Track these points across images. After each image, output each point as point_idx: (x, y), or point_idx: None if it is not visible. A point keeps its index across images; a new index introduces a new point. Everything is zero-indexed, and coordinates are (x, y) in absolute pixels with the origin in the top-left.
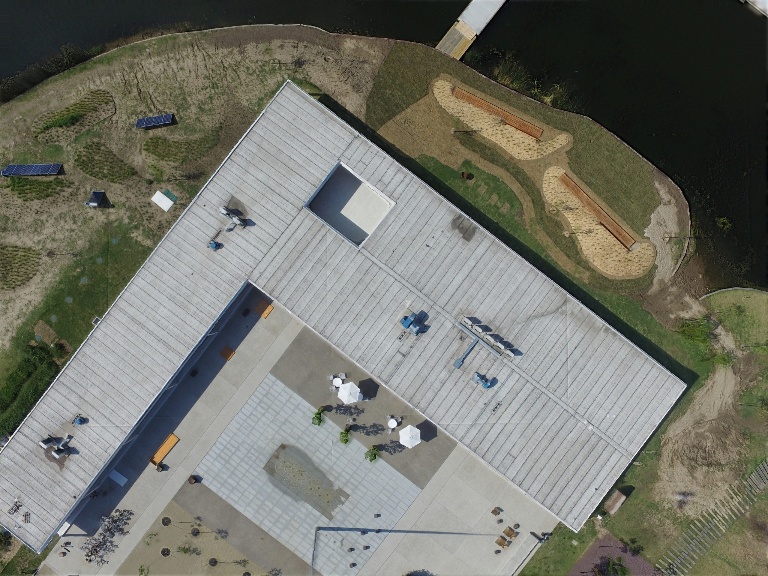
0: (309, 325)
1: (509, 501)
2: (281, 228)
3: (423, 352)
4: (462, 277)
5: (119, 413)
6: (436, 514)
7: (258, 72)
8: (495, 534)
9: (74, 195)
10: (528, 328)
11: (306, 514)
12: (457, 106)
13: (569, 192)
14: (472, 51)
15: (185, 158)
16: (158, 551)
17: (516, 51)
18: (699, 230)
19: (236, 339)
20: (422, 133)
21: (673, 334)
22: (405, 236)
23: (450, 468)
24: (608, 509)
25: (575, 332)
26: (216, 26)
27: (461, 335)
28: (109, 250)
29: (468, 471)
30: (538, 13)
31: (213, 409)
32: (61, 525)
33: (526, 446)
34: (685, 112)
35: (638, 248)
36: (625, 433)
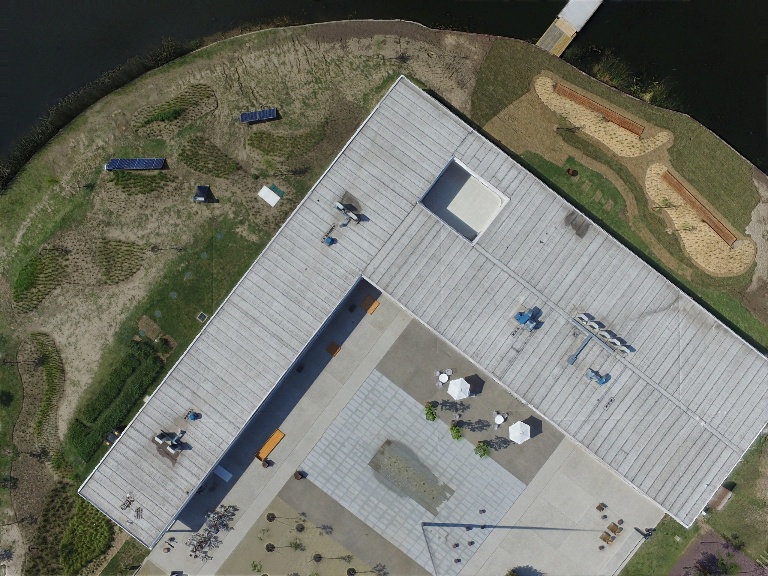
0: (423, 321)
1: (613, 497)
2: (395, 224)
3: (537, 348)
4: (575, 273)
5: (232, 408)
6: (541, 510)
7: (362, 67)
8: (599, 530)
9: (178, 190)
10: (641, 324)
11: (411, 510)
12: (559, 103)
13: (671, 189)
14: (572, 48)
15: (291, 153)
16: (262, 547)
17: (615, 48)
18: None
19: (342, 335)
20: (526, 129)
21: None
22: (519, 232)
23: (555, 464)
24: (714, 505)
25: (687, 329)
26: (315, 21)
27: (574, 331)
28: (214, 245)
29: (573, 467)
30: (636, 10)
31: (318, 405)
32: (173, 520)
33: (638, 442)
34: None
35: (740, 245)
36: (736, 429)
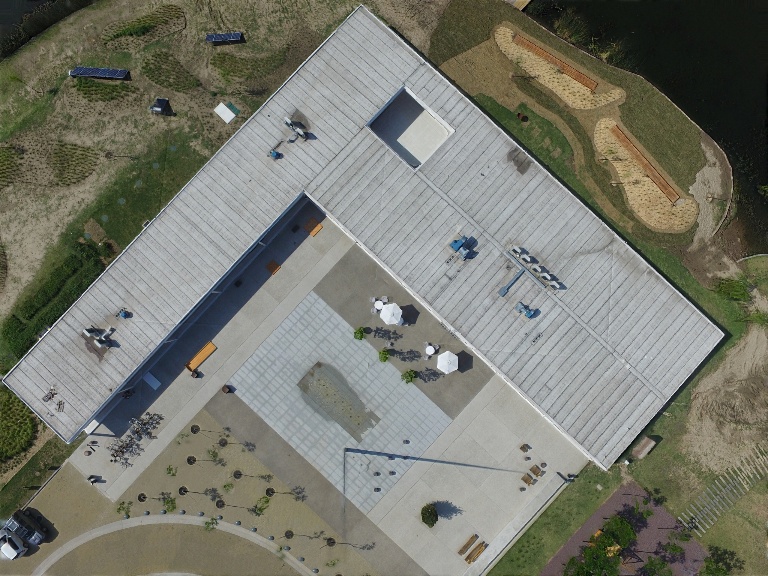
0: (360, 240)
1: (538, 439)
2: (341, 144)
3: (469, 277)
4: (513, 208)
5: (164, 310)
6: (465, 446)
7: (328, 1)
8: (522, 471)
9: (138, 100)
10: (574, 264)
11: (335, 434)
12: (517, 52)
13: (619, 144)
14: (534, 4)
15: (250, 75)
16: (184, 458)
17: (576, 8)
18: (740, 195)
19: (283, 254)
20: (481, 74)
21: (709, 293)
22: (461, 163)
23: (482, 401)
24: (637, 454)
25: (619, 272)
26: None
27: (508, 264)
28: (167, 156)
29: (500, 405)
30: None
31: (253, 321)
32: (94, 417)
33: (563, 379)
34: (734, 82)
35: (682, 204)
36: (661, 376)
